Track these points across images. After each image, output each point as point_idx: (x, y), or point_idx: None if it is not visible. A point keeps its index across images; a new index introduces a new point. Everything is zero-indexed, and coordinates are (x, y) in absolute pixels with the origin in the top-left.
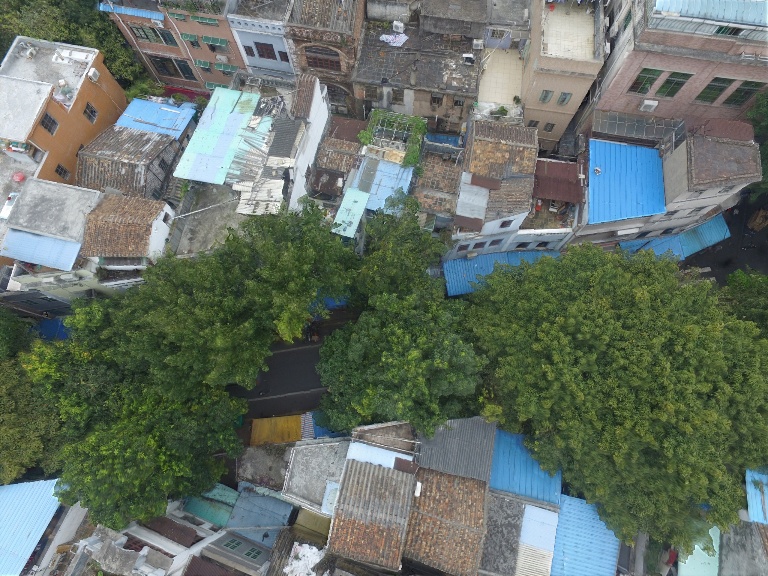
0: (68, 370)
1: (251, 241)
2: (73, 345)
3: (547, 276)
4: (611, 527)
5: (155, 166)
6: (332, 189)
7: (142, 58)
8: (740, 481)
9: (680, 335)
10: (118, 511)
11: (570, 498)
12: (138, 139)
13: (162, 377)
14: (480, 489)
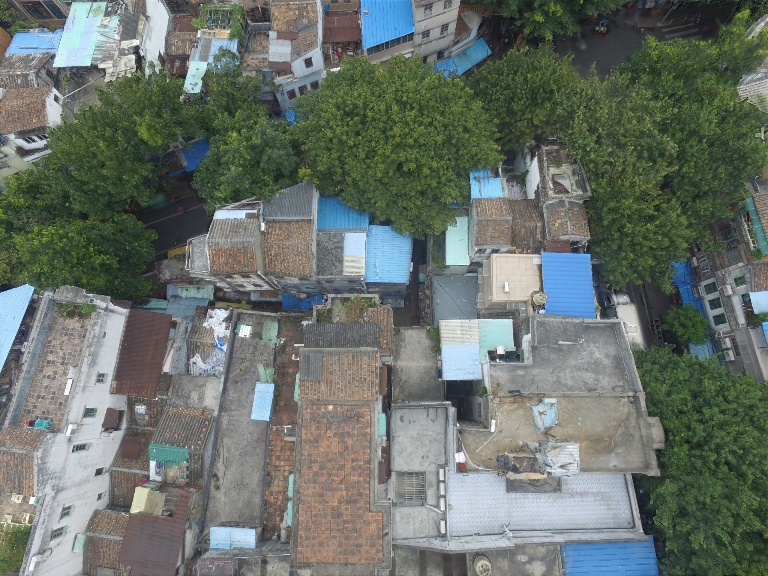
0: (13, 214)
1: (118, 97)
2: (12, 197)
3: (331, 84)
4: (398, 231)
5: (43, 74)
6: (184, 70)
7: (16, 5)
8: (468, 181)
9: (406, 92)
10: (65, 270)
11: (376, 226)
12: (25, 59)
13: (78, 197)
14: (308, 224)
